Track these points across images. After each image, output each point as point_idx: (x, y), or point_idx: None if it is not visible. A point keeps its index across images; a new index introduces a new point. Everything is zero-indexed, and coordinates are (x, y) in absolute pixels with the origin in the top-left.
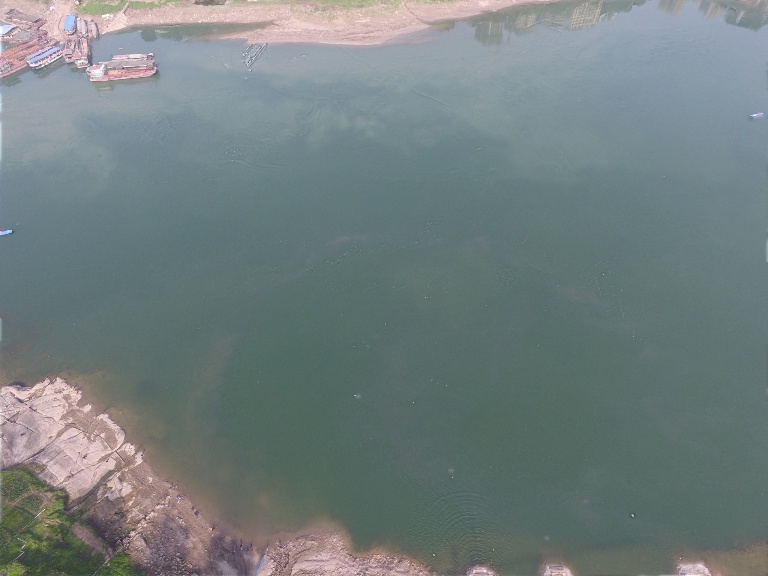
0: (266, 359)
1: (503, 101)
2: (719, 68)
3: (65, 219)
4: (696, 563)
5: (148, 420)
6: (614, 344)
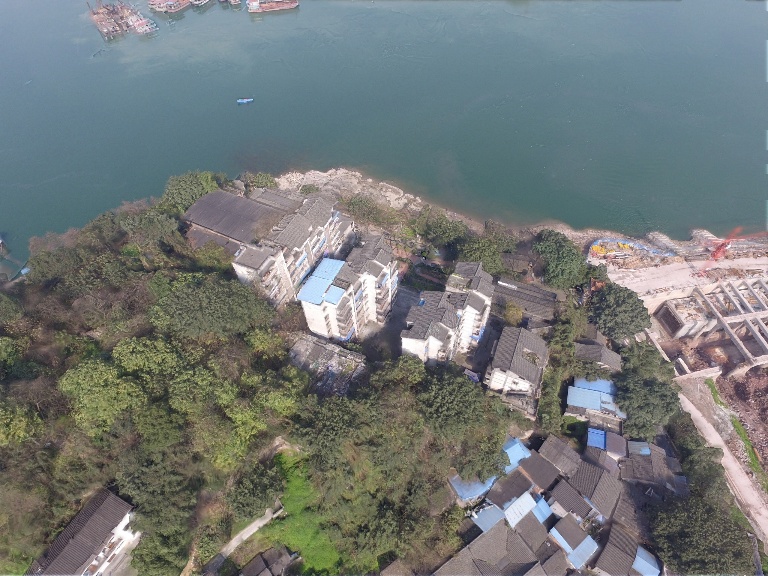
0: (475, 154)
1: (580, 16)
2: None
3: (285, 93)
4: None
5: None
6: (706, 139)
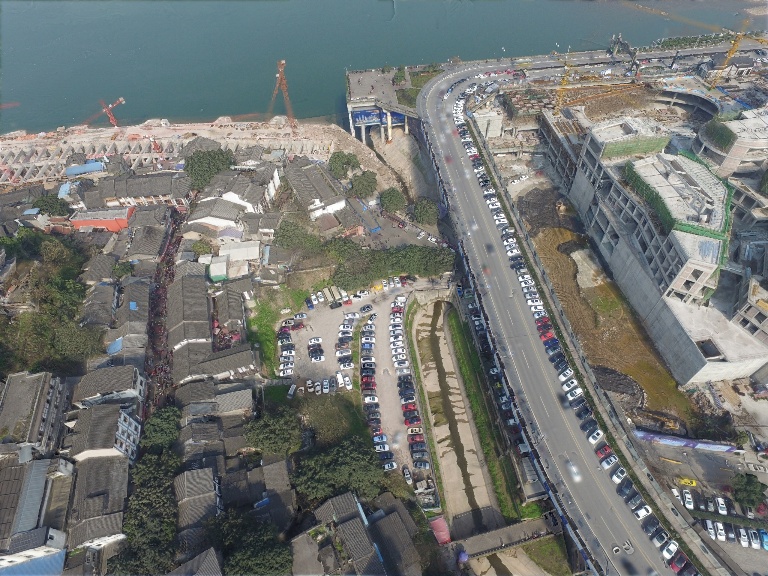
0: None
1: None
2: None
3: None
4: None
5: None
6: (120, 72)
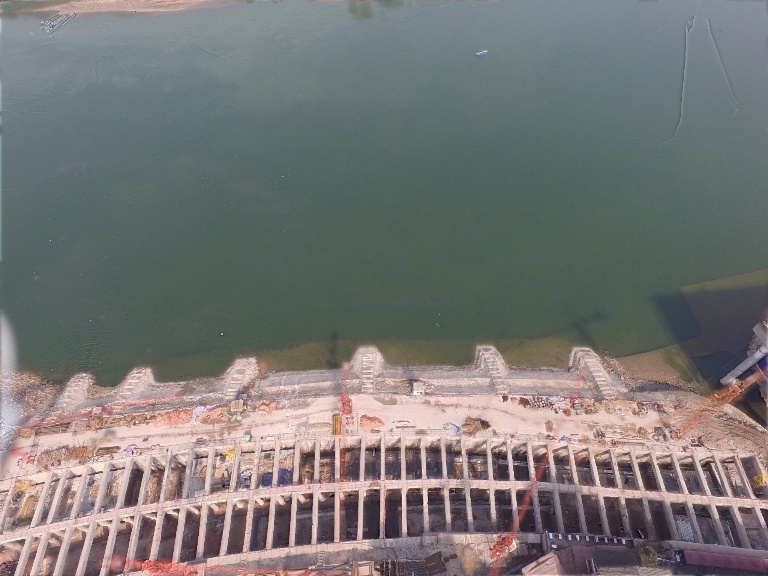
0: None
1: (275, 52)
2: (482, 18)
3: None
4: (250, 357)
5: None
6: (267, 225)
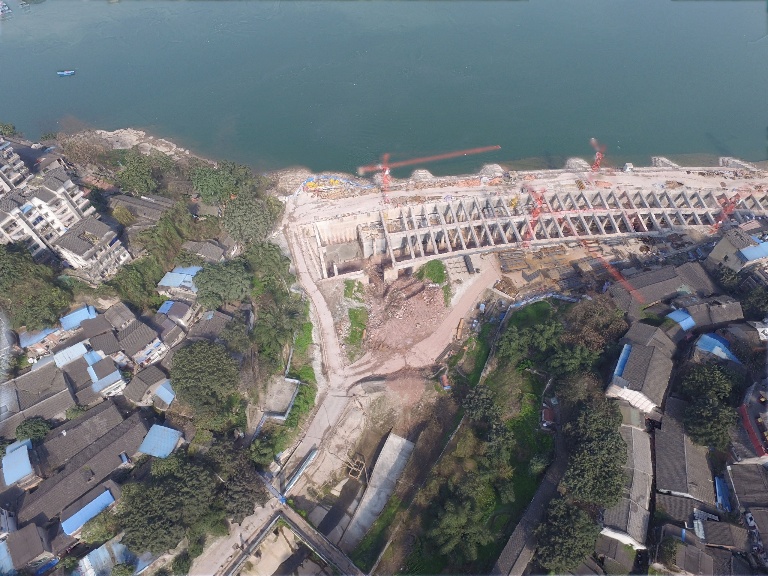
0: (256, 114)
1: None
2: None
3: (108, 66)
4: (493, 164)
5: (189, 140)
6: (468, 96)
